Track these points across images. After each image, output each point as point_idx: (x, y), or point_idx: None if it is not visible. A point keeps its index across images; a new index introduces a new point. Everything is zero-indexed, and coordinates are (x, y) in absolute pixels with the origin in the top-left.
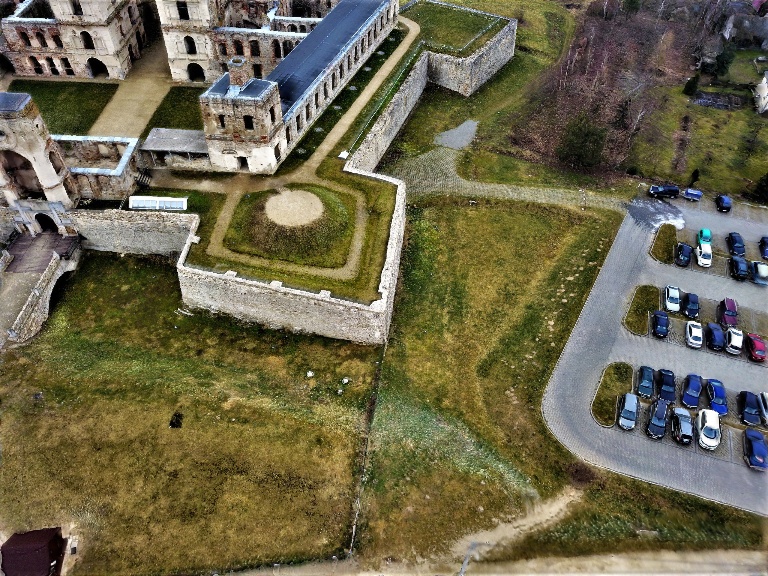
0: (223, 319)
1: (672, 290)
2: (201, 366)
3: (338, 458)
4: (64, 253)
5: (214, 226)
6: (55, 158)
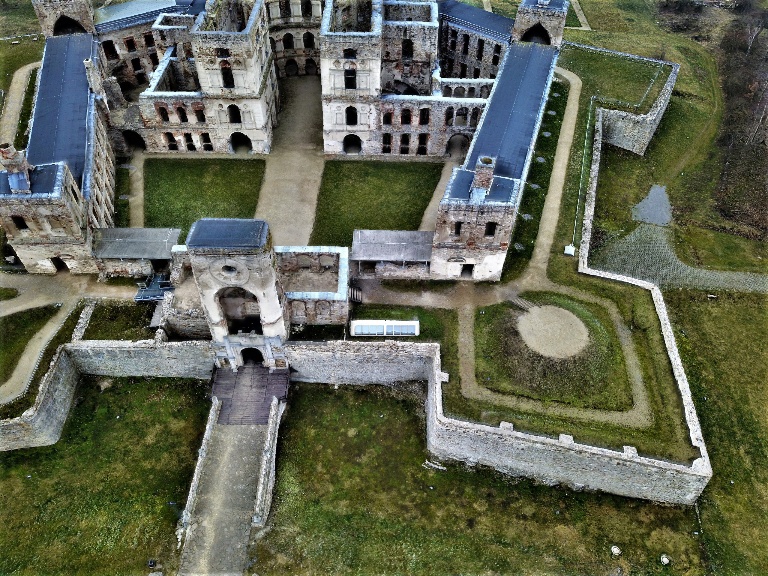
0: (484, 473)
1: None
2: (484, 546)
3: None
4: (282, 396)
5: (457, 356)
6: (277, 287)
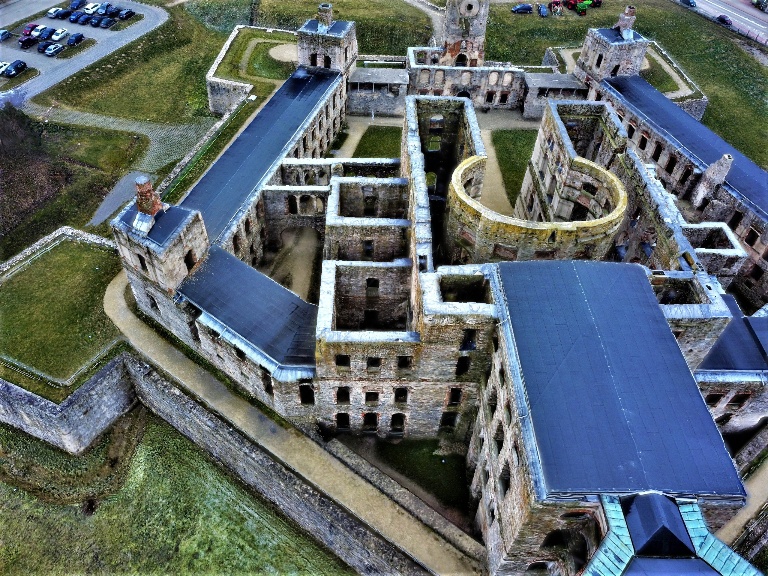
0: None
1: (52, 47)
2: None
3: (266, 3)
4: None
5: None
6: None
